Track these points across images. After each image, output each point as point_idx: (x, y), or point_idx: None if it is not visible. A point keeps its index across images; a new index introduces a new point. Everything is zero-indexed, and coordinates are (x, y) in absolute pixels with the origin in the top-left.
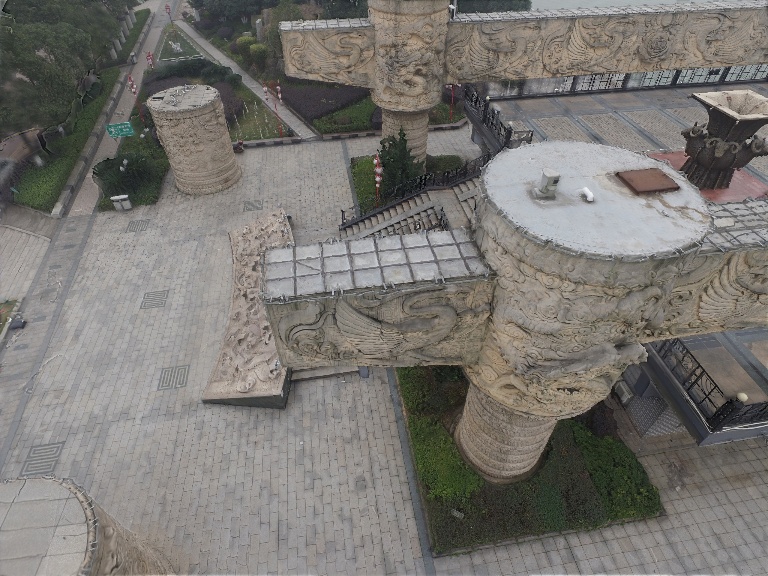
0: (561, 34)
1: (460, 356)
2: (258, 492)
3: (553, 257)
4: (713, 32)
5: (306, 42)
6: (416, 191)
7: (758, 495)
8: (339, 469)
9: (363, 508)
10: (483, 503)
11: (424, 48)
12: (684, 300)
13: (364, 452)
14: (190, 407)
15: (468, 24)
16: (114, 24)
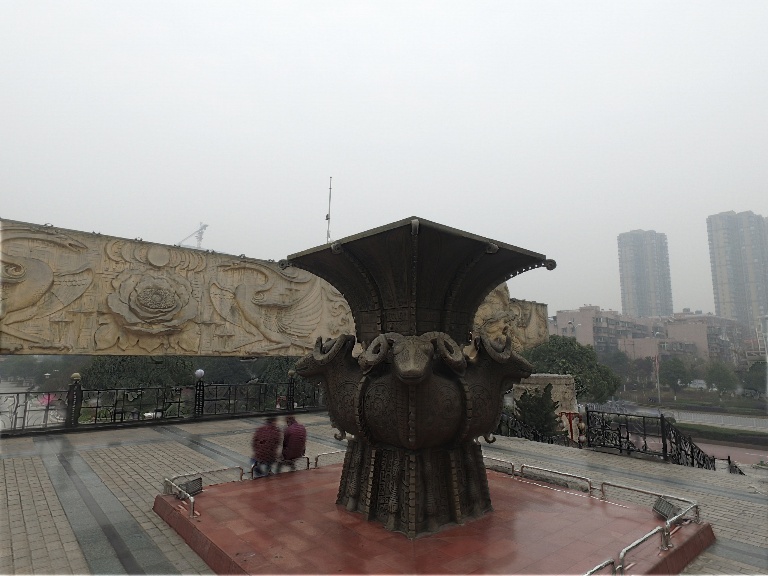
0: None
1: None
2: None
3: None
4: None
5: None
6: None
7: None
8: None
9: None
10: None
11: None
12: None
13: None
14: None
15: None
16: None
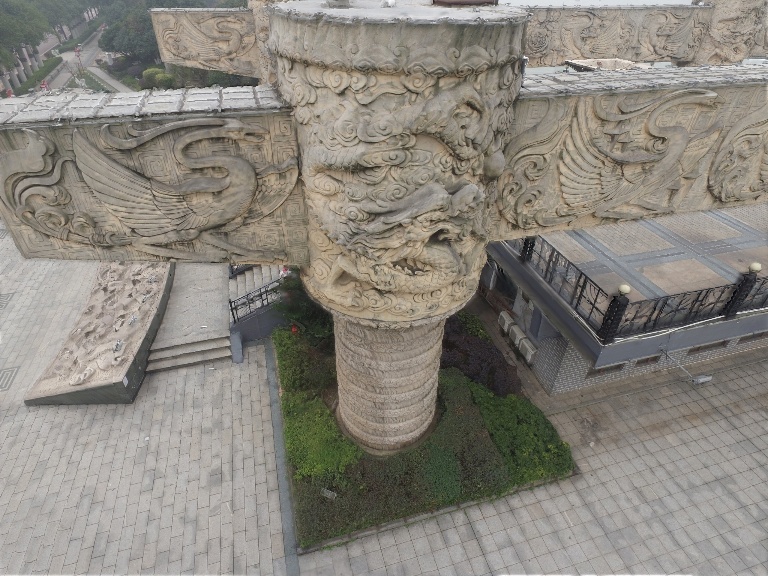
0: None
1: (283, 249)
2: (76, 502)
3: (331, 37)
4: (586, 30)
5: (180, 25)
6: None
7: (678, 442)
8: (190, 464)
9: (214, 506)
10: (360, 476)
11: None
12: (540, 170)
13: (225, 441)
14: (7, 412)
15: None
16: (5, 54)
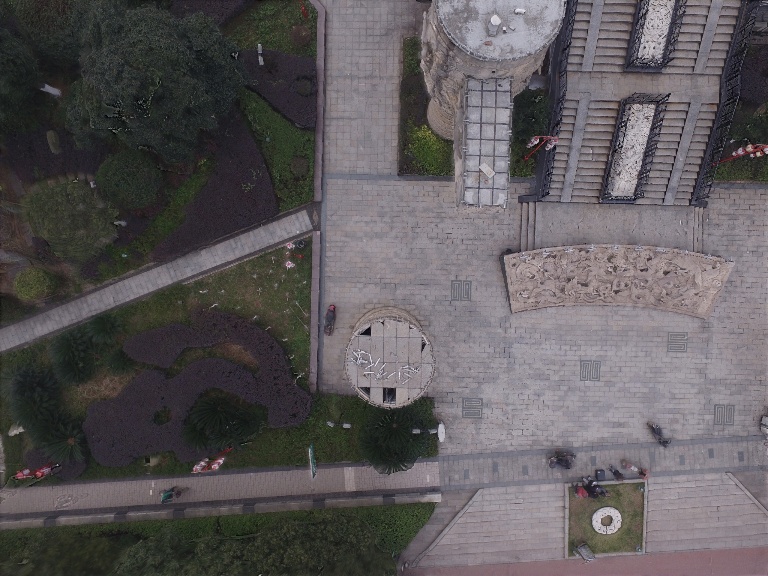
0: None
1: None
2: None
3: None
4: None
5: None
6: (557, 110)
7: None
8: None
9: None
10: None
11: None
12: None
13: (763, 213)
14: (706, 327)
15: None
16: None
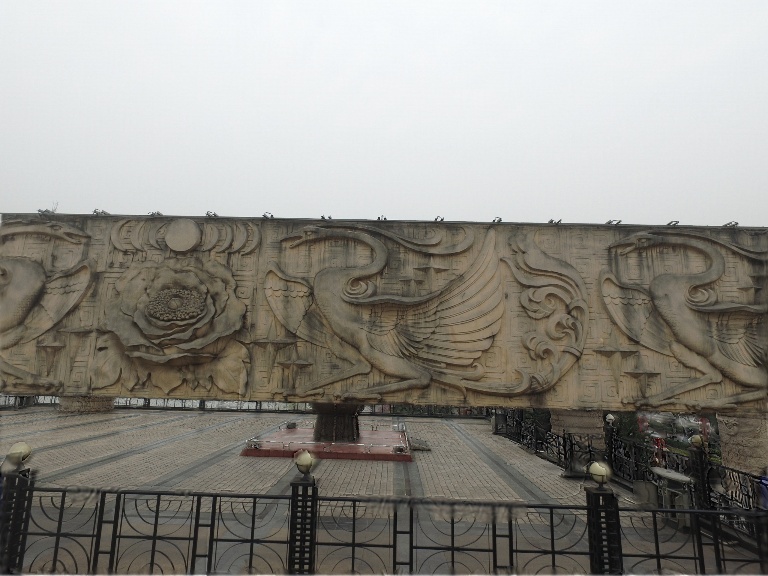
0: None
1: None
2: None
3: None
4: None
5: None
6: None
7: None
8: None
9: None
10: None
11: None
12: None
13: None
14: None
15: None
16: None
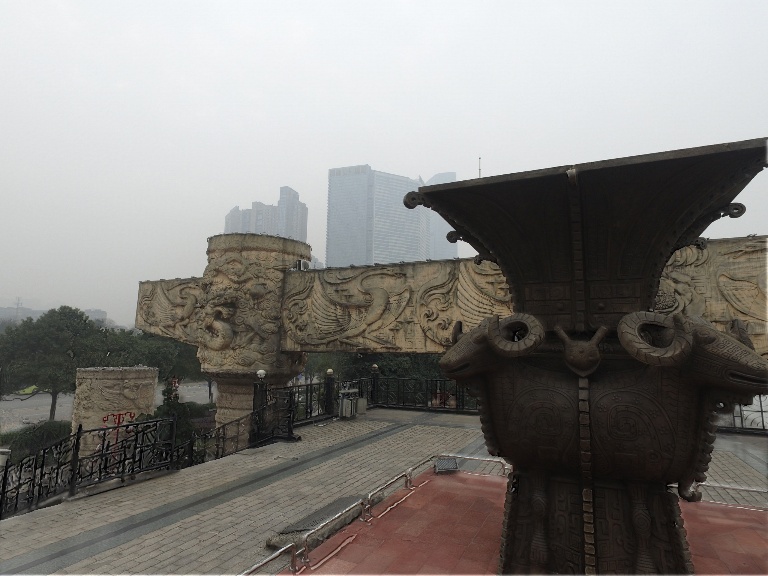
0: (439, 283)
1: None
2: None
3: None
4: None
5: (155, 293)
6: None
7: None
8: None
9: None
10: None
11: (232, 289)
12: None
13: None
14: None
15: (309, 273)
16: None
